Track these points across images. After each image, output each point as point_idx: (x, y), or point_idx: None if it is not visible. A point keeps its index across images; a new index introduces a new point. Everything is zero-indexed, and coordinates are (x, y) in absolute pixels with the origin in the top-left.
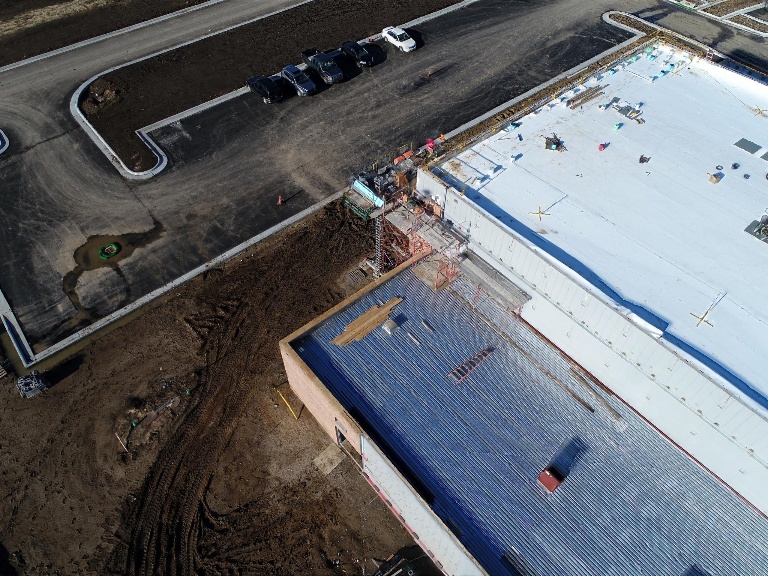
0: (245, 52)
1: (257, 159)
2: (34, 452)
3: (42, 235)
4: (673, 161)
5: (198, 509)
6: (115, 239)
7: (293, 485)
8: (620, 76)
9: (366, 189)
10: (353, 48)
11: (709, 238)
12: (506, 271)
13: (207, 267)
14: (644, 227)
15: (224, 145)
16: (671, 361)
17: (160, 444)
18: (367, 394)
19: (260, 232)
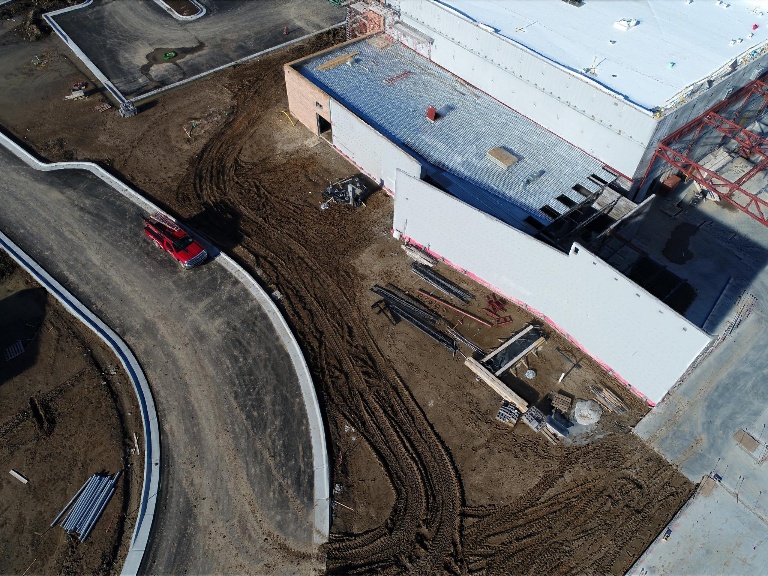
0: None
1: (269, 11)
2: (134, 139)
3: (123, 47)
4: None
5: (234, 160)
6: (173, 50)
7: (291, 152)
8: None
9: None
10: None
11: (537, 2)
12: (420, 26)
13: (236, 62)
14: None
15: (246, 3)
16: (497, 43)
17: (210, 135)
18: (335, 88)
19: (271, 47)
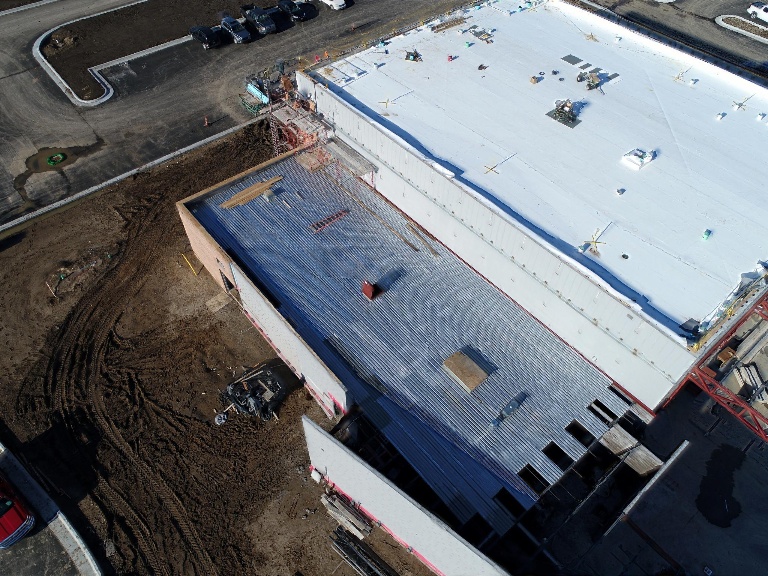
0: (192, 8)
1: (192, 92)
2: None
3: None
4: (506, 69)
5: (108, 334)
6: (62, 150)
7: (187, 319)
8: (484, 11)
9: (256, 90)
10: (287, 4)
11: (516, 119)
12: (360, 149)
13: (137, 170)
14: (467, 112)
15: (164, 81)
16: (459, 195)
17: (83, 292)
18: (242, 240)
19: (186, 146)
